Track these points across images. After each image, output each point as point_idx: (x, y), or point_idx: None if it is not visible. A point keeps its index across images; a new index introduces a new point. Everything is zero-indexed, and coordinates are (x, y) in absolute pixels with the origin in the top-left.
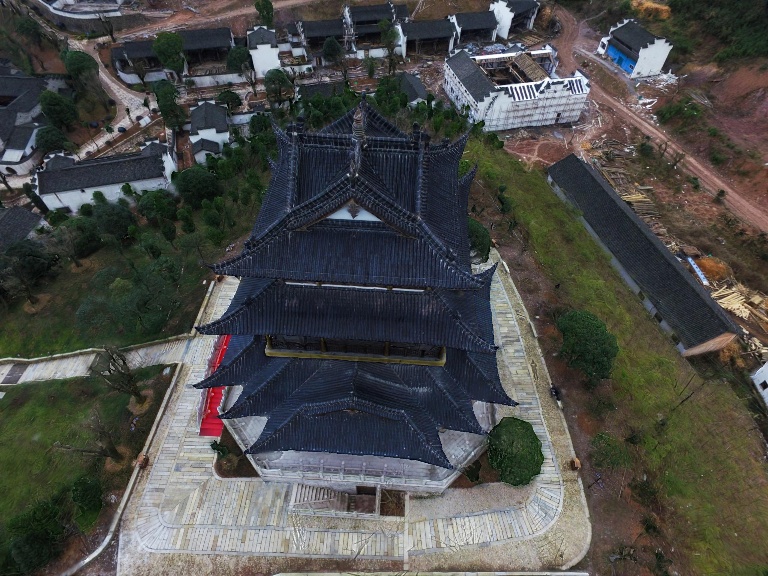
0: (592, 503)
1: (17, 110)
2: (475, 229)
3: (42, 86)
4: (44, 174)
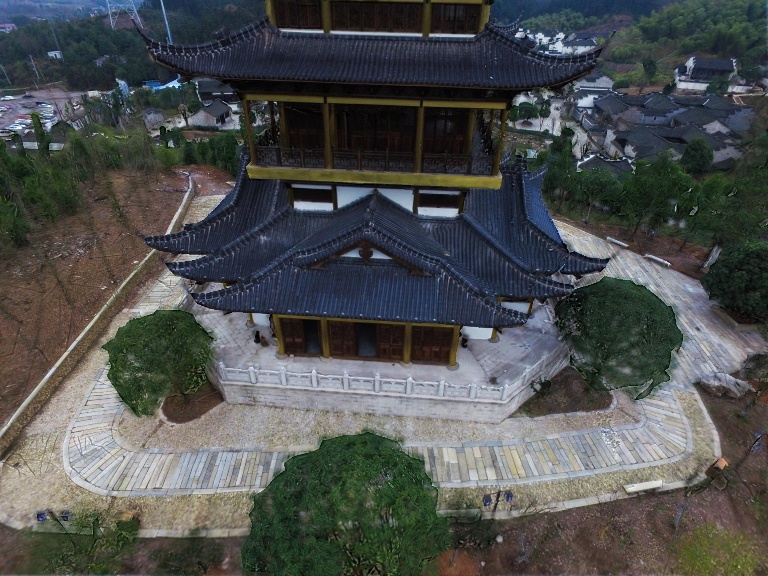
0: (48, 542)
1: (674, 147)
2: (621, 297)
3: (719, 147)
4: (598, 159)
